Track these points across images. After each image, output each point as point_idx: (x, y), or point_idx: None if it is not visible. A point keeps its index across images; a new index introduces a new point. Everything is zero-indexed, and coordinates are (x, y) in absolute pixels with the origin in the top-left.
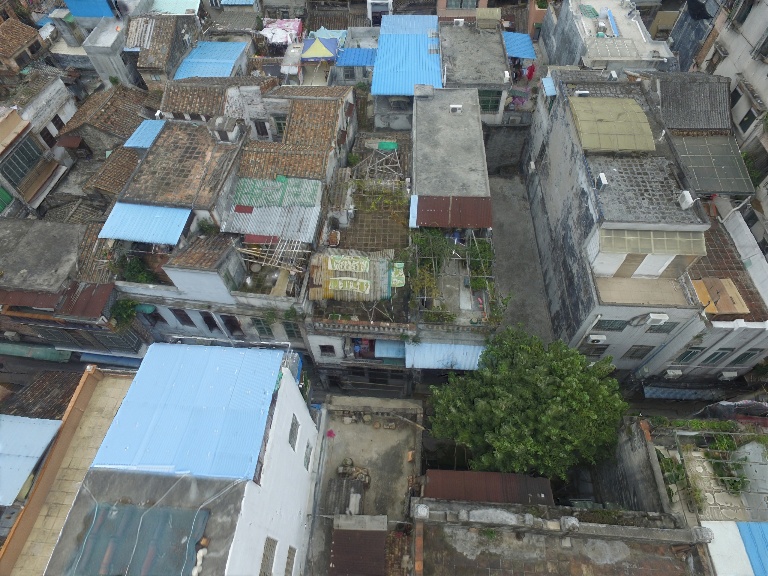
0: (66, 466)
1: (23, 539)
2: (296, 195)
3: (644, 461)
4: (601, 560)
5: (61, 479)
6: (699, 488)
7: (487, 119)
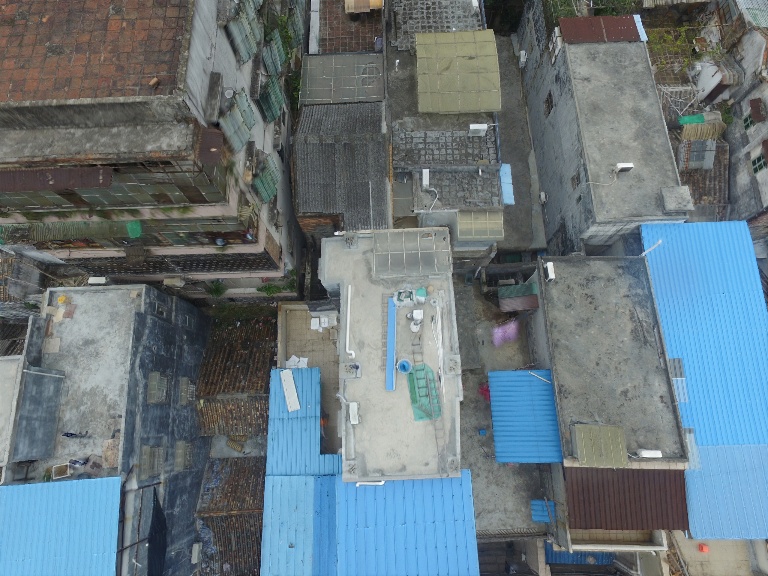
0: None
1: None
2: None
3: None
4: None
5: None
6: None
7: None
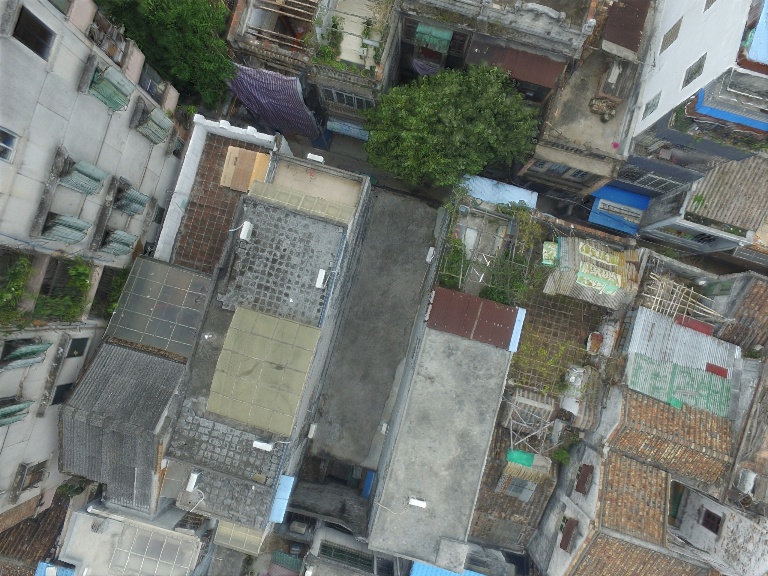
0: None
1: None
2: (657, 375)
3: None
4: None
5: None
6: (386, 4)
7: (336, 539)
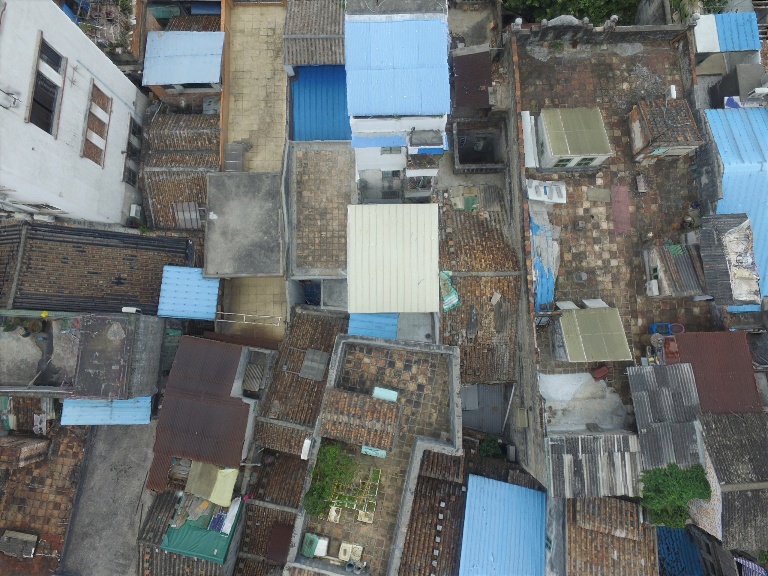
0: (234, 70)
1: (227, 114)
2: None
3: (658, 5)
4: (625, 54)
5: (234, 78)
6: None
7: None
